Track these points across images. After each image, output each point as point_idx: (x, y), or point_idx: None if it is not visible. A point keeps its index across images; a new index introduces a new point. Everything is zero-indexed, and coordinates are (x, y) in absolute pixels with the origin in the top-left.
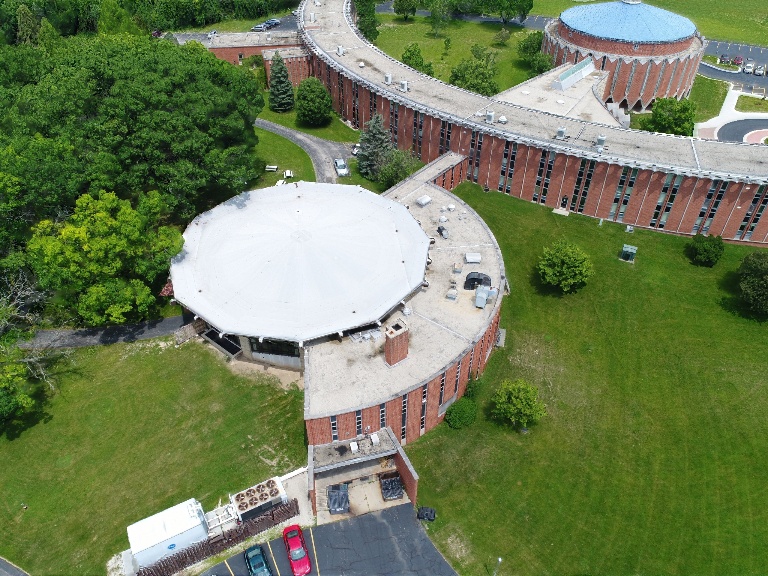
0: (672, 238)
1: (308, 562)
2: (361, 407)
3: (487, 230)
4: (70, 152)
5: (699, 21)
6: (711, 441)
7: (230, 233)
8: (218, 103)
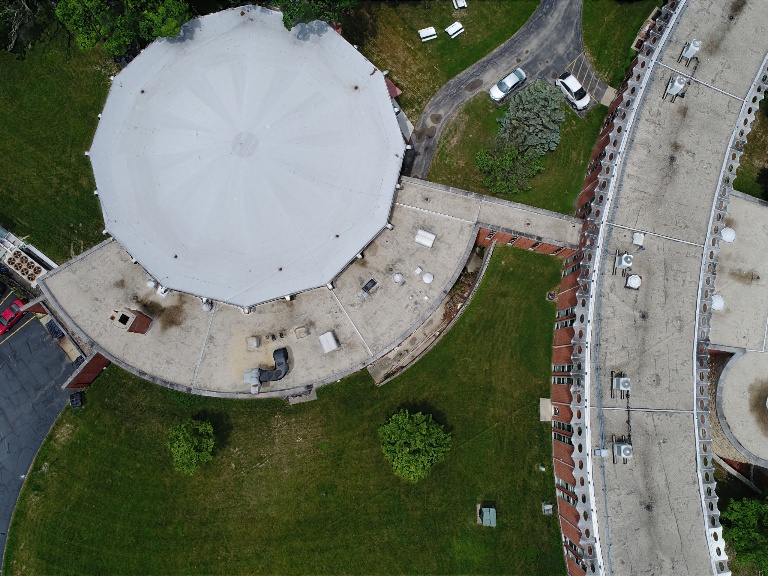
0: (557, 567)
1: (3, 330)
2: (66, 320)
3: (397, 339)
4: None
5: None
6: None
7: (245, 58)
8: None
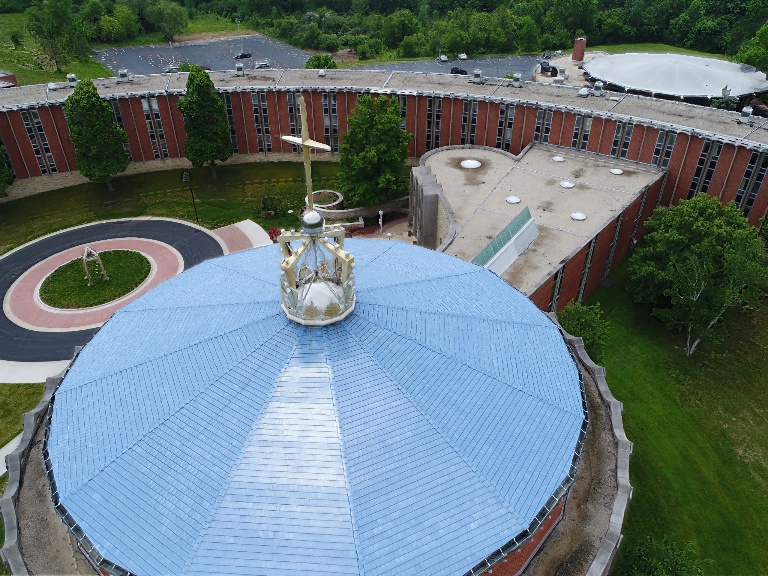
0: None
1: None
2: None
3: None
4: None
5: None
6: None
7: None
8: None
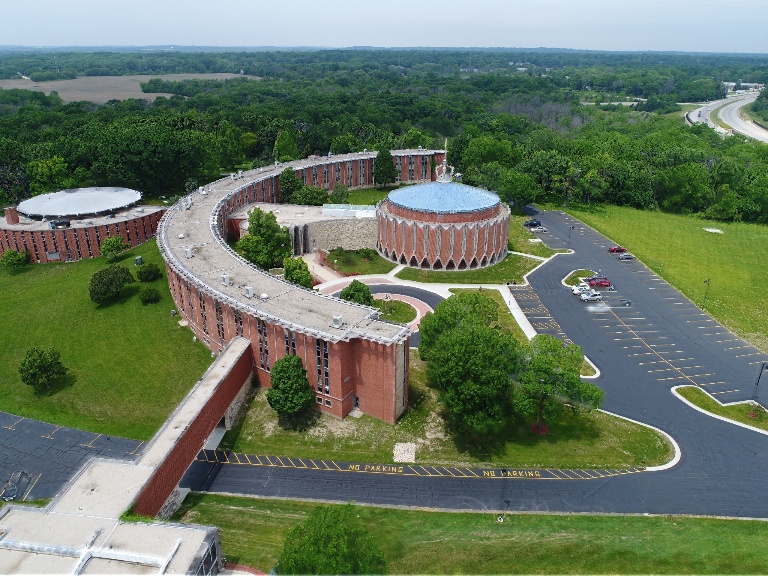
0: (165, 269)
1: None
2: None
3: None
4: (82, 148)
5: (744, 270)
6: (3, 305)
7: None
8: (131, 149)
